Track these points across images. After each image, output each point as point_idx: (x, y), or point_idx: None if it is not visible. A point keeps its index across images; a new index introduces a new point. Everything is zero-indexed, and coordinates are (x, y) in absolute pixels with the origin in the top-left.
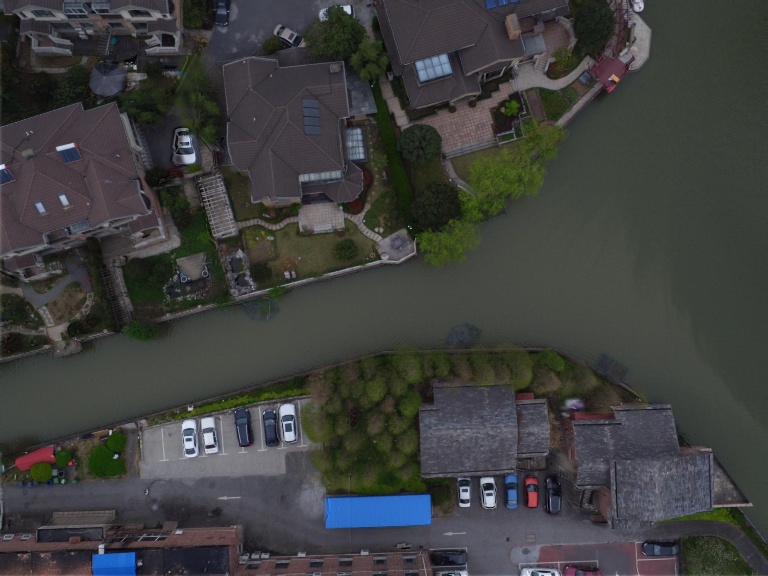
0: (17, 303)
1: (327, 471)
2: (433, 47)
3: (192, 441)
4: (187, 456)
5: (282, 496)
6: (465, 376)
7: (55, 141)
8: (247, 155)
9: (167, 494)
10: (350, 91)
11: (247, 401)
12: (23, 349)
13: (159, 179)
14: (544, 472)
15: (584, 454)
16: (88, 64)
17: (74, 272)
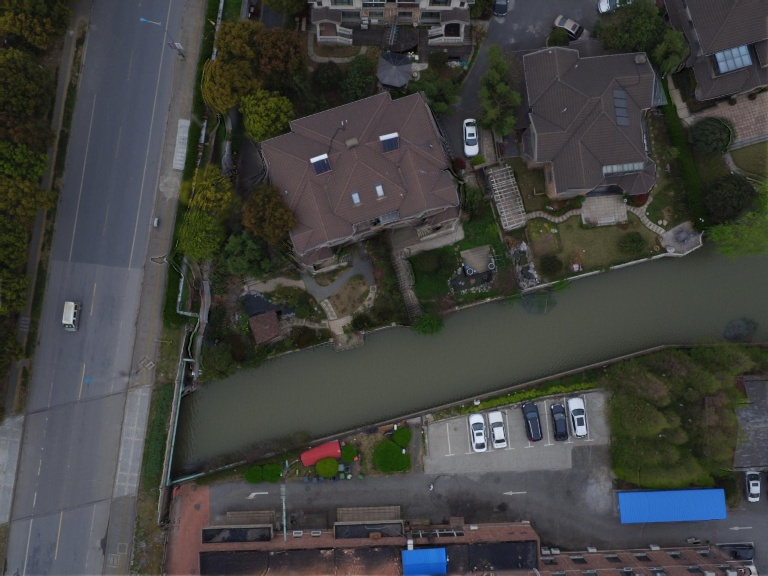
0: (300, 296)
1: (615, 465)
2: (735, 38)
3: (483, 435)
4: (477, 451)
5: (568, 491)
6: None
7: (375, 130)
8: (553, 146)
9: (452, 489)
10: (656, 82)
11: (535, 395)
12: (311, 342)
13: (461, 170)
14: None
15: None
16: (372, 54)
17: (358, 264)
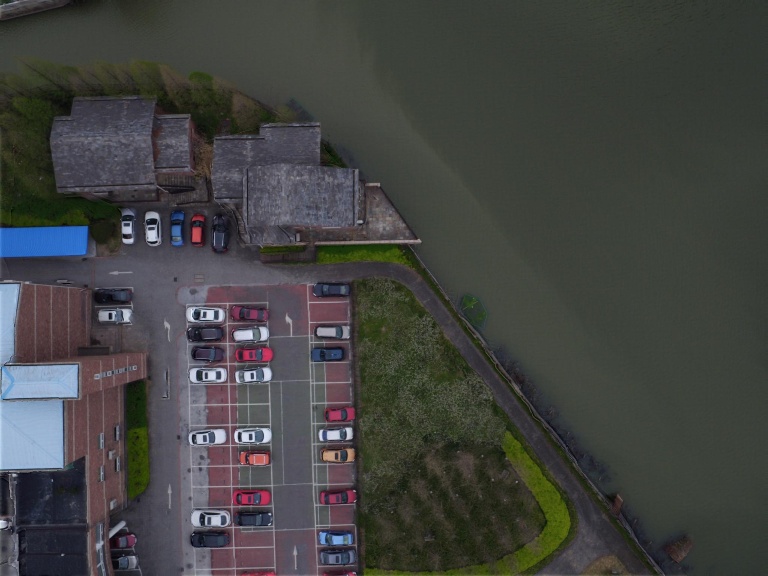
0: None
1: None
2: None
3: None
4: None
5: None
6: (112, 95)
7: None
8: None
9: None
10: None
11: None
12: None
13: None
14: (211, 209)
15: (220, 164)
16: None
17: None
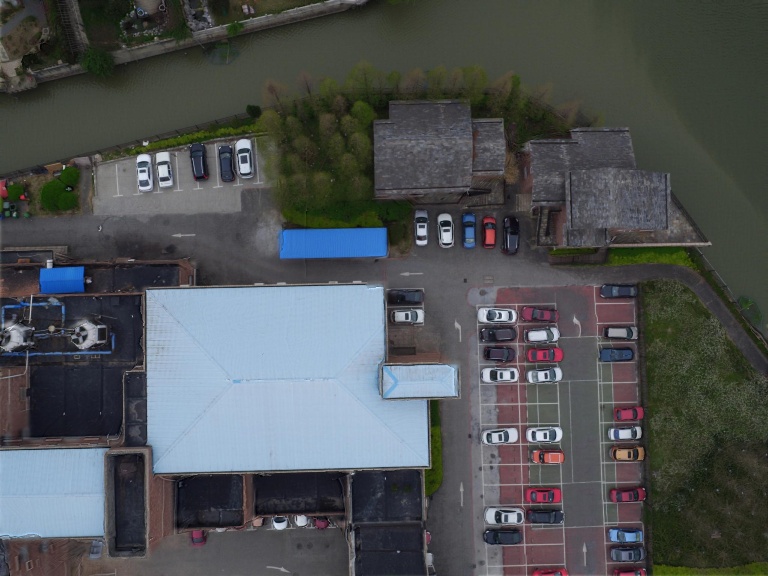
0: None
1: (283, 207)
2: None
3: (146, 173)
4: (141, 188)
5: (237, 234)
6: (422, 99)
7: None
8: None
9: (121, 231)
10: None
11: (203, 136)
12: None
13: None
14: (502, 211)
15: (539, 168)
16: None
17: (29, 5)
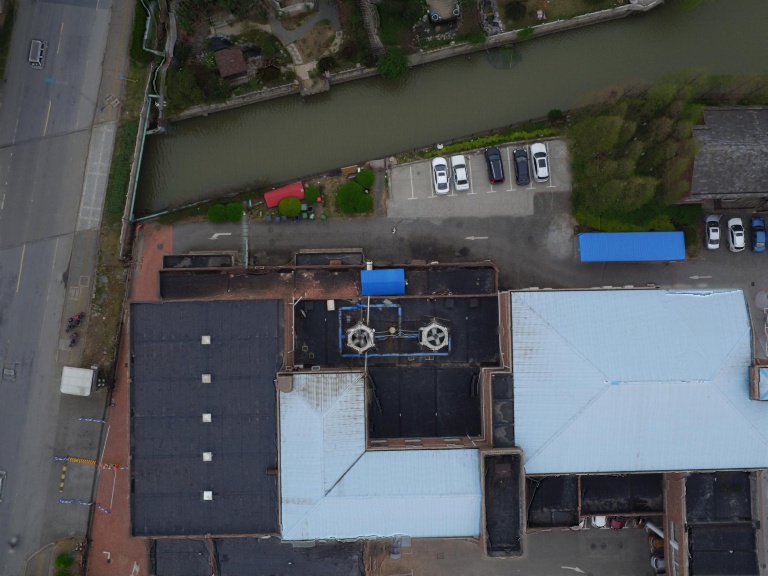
0: (266, 39)
1: (576, 211)
2: None
3: (445, 176)
4: (439, 191)
5: (530, 237)
6: (728, 105)
7: None
8: None
9: (414, 233)
10: None
11: (497, 140)
12: (275, 81)
13: None
14: None
15: None
16: None
17: (324, 9)
